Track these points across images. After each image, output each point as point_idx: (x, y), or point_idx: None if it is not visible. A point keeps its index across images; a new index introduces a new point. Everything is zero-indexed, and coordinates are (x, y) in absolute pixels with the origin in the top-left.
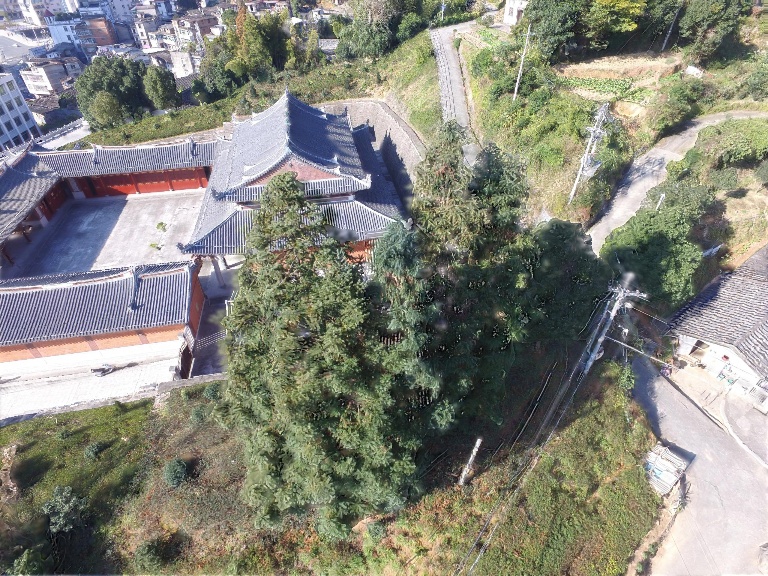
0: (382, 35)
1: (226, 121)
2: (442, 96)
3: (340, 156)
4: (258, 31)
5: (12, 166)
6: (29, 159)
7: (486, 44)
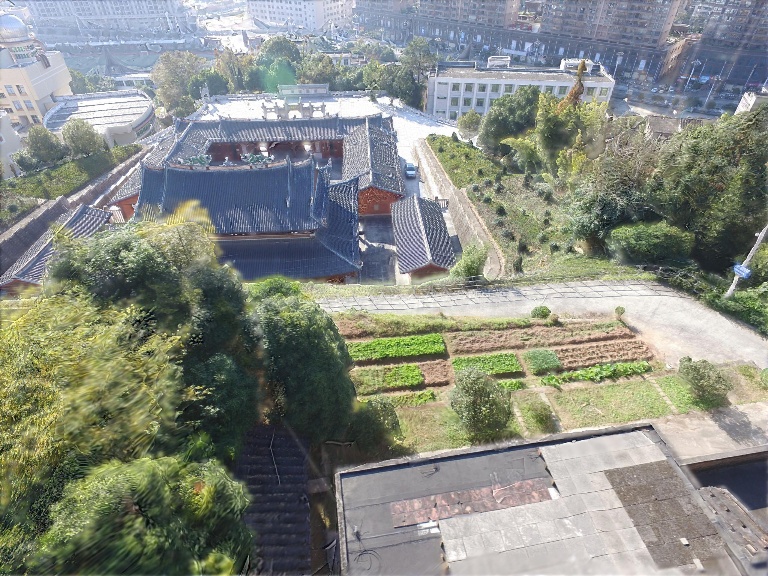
0: (584, 218)
1: (460, 187)
2: (315, 299)
3: (181, 214)
4: (542, 120)
5: (343, 118)
6: (360, 121)
7: (491, 352)
